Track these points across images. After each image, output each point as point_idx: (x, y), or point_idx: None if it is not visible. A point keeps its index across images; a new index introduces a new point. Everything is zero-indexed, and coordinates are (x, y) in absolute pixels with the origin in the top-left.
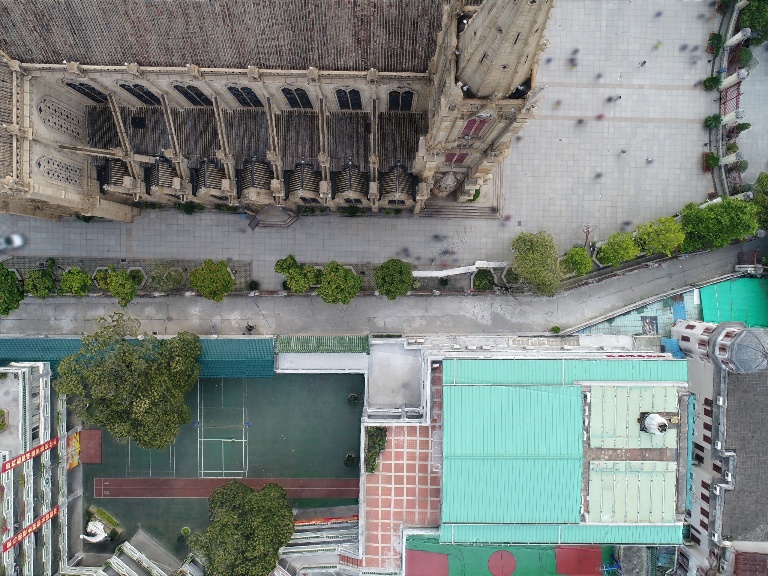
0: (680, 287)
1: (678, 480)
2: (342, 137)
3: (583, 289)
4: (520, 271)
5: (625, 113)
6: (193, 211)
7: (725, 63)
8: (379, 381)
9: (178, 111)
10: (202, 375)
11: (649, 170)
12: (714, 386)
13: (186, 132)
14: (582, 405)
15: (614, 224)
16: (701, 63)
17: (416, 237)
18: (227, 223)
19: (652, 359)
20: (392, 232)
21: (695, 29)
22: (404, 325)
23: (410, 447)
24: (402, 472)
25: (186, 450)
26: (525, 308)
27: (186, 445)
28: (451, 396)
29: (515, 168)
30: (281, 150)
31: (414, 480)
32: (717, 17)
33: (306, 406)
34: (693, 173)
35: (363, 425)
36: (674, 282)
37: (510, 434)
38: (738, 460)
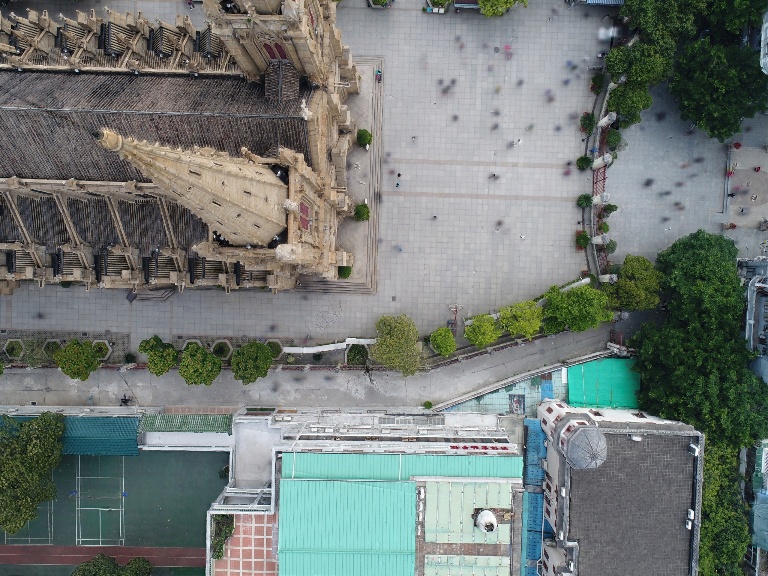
0: (553, 363)
1: (512, 575)
2: (196, 226)
3: (456, 365)
4: (375, 357)
5: (499, 191)
6: (71, 284)
7: (597, 143)
8: (246, 458)
9: (34, 200)
10: (68, 452)
11: (523, 247)
12: (559, 477)
13: (43, 220)
14: (417, 500)
15: (488, 300)
16: (575, 142)
17: (292, 311)
18: (105, 296)
19: (488, 455)
20: (268, 306)
21: (569, 108)
22: (279, 398)
23: (258, 533)
24: (250, 558)
25: (64, 518)
26: (399, 382)
27: (64, 513)
28: (287, 490)
29: (390, 244)
30: (137, 238)
31: (262, 566)
32: (591, 96)
33: (182, 477)
34: (566, 251)
35: (209, 513)
36: (547, 358)
37: (344, 529)
38: (582, 550)
